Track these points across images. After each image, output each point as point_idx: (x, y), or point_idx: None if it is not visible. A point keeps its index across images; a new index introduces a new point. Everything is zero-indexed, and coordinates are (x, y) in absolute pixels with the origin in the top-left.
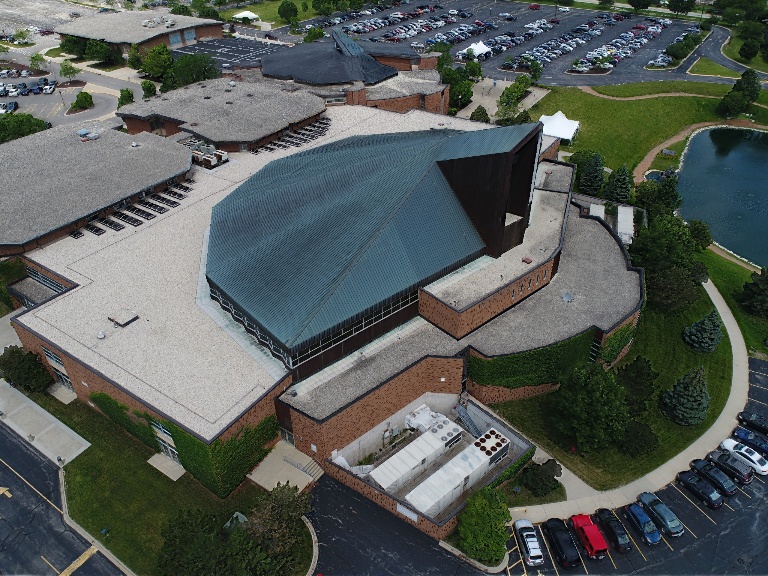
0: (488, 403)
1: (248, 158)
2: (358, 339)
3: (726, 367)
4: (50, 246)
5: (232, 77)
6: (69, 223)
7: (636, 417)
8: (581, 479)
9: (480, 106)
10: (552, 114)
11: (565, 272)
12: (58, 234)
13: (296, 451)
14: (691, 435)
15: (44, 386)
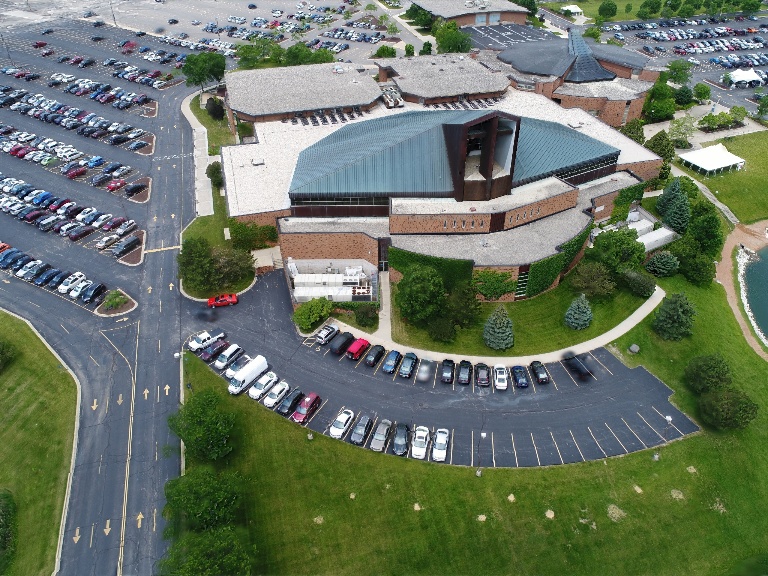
0: (393, 281)
1: (418, 108)
2: (339, 210)
3: (572, 341)
4: (268, 122)
5: (468, 53)
6: (281, 113)
7: (465, 328)
8: (391, 332)
9: (635, 118)
10: (736, 149)
11: (510, 233)
12: (276, 118)
13: (279, 253)
14: (486, 353)
15: (217, 183)
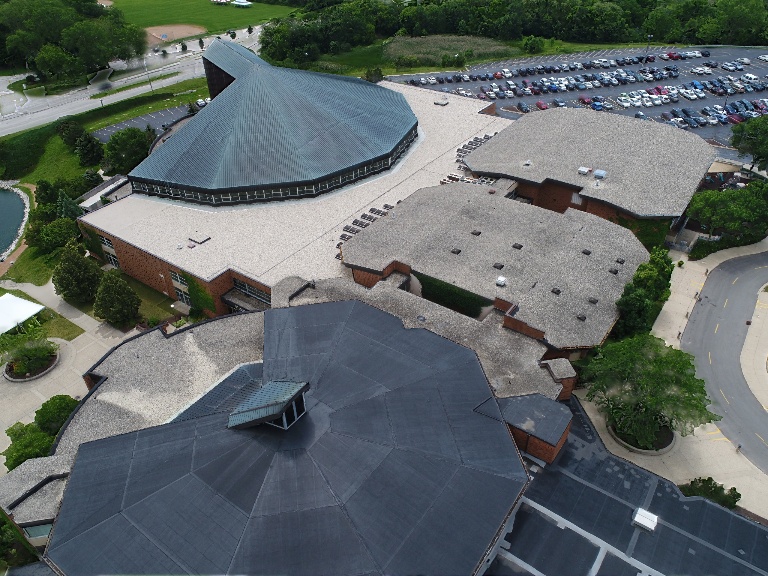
0: None
1: None
2: None
3: None
4: None
5: None
6: None
7: None
8: None
9: None
10: None
11: None
12: None
13: None
14: None
15: None
